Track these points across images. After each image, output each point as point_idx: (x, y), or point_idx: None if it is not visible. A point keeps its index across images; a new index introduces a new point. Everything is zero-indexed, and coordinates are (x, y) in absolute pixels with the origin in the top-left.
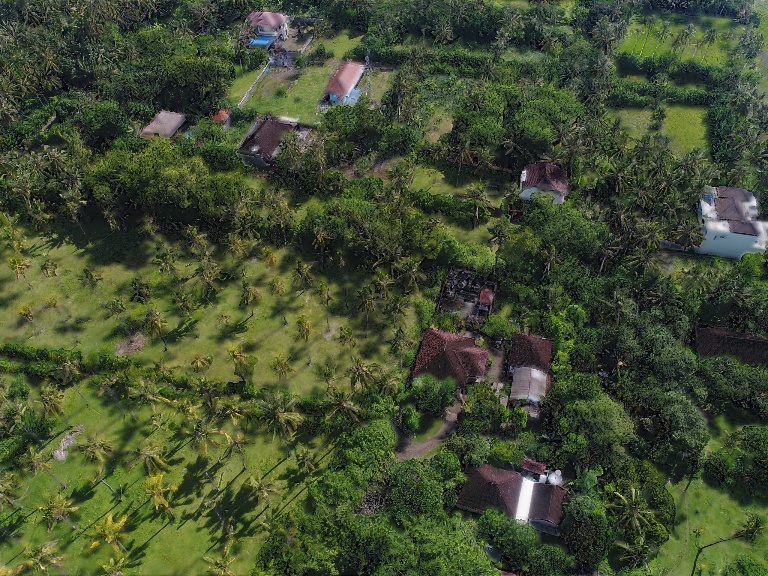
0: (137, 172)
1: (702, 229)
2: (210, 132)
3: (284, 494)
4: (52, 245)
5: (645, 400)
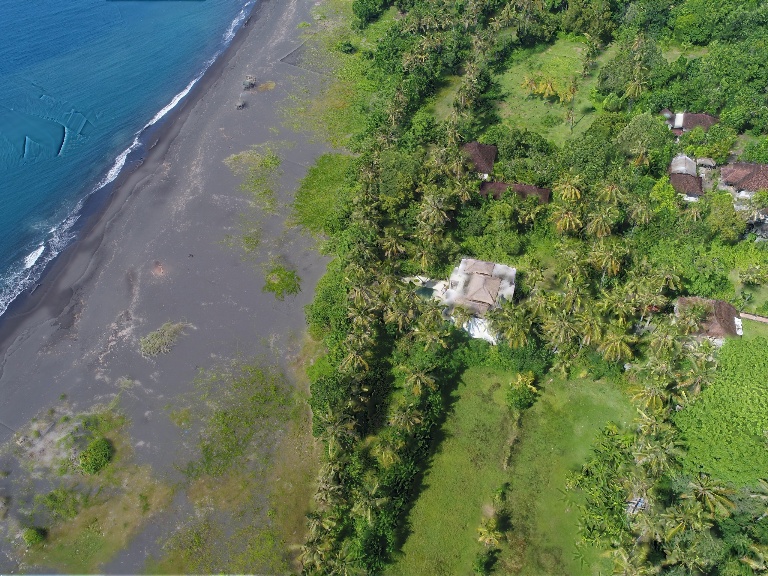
0: None
1: None
2: None
3: None
4: None
5: None
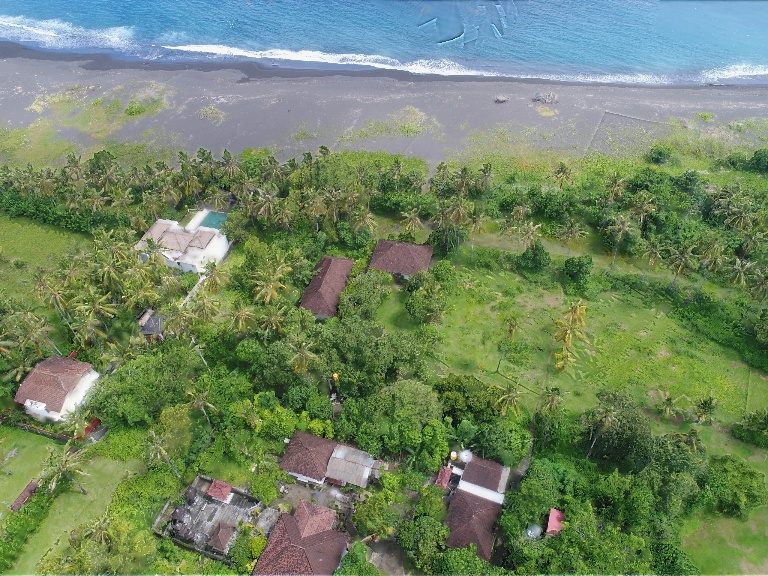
0: None
1: (184, 269)
2: None
3: None
4: None
5: (385, 364)
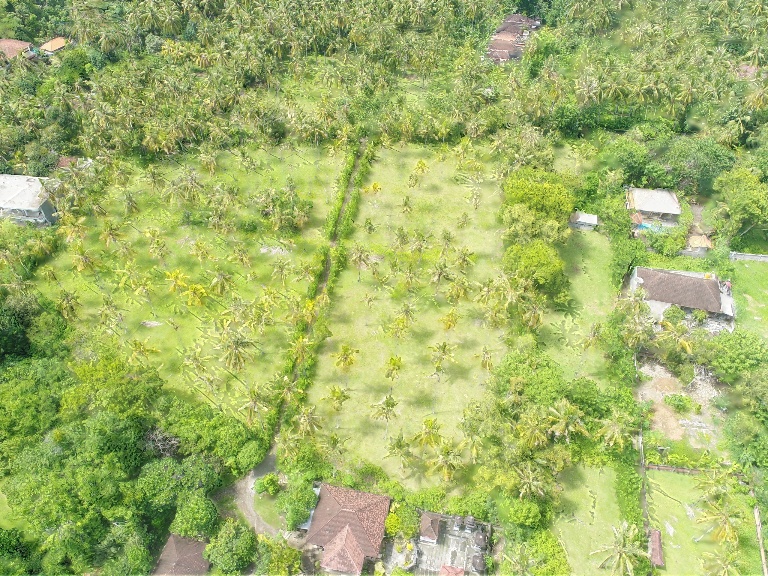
0: (520, 186)
1: None
2: (659, 236)
3: (214, 390)
4: (468, 182)
5: None
